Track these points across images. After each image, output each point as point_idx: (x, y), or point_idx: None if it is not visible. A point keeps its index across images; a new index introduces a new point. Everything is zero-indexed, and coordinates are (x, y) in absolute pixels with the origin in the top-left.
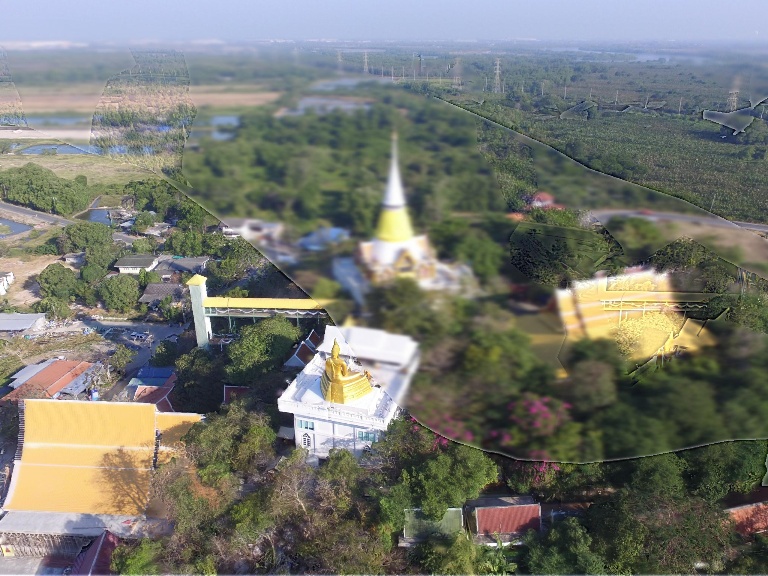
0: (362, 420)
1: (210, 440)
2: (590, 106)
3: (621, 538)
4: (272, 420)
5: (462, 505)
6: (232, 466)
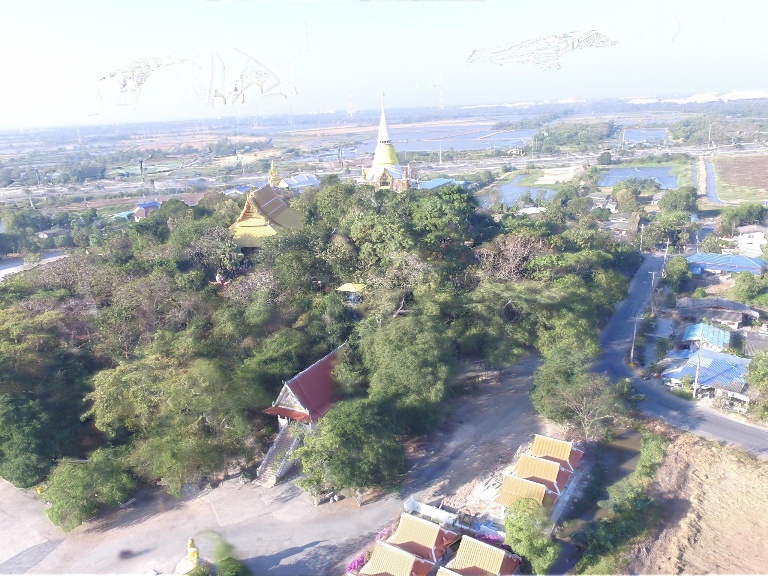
0: None
1: None
2: (435, 75)
3: None
4: None
5: None
6: None
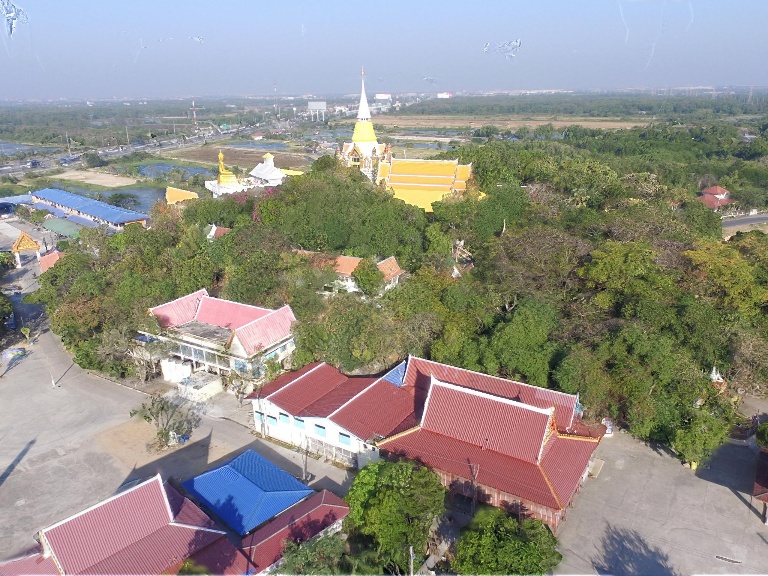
0: None
1: None
2: None
3: None
4: None
5: (216, 225)
6: None
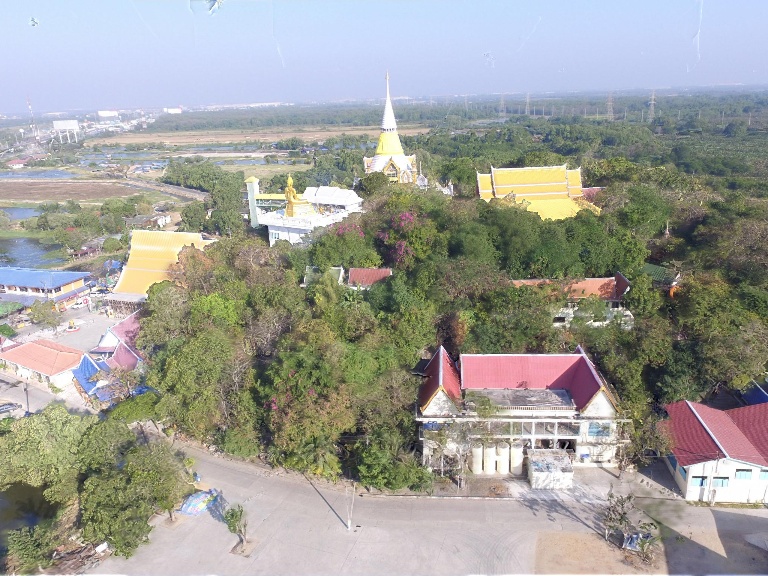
0: (300, 224)
1: (221, 244)
2: None
3: (420, 272)
4: (262, 240)
5: (343, 267)
6: (230, 259)
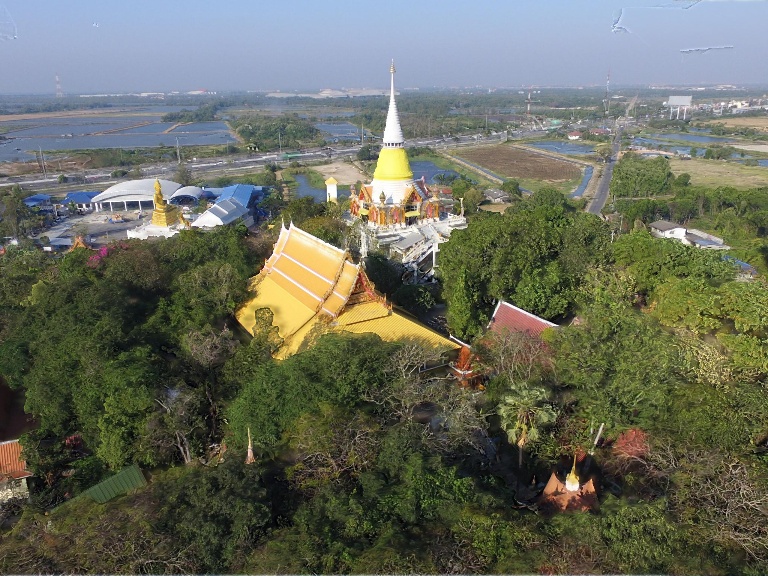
0: None
1: None
2: None
3: None
4: None
5: None
6: None
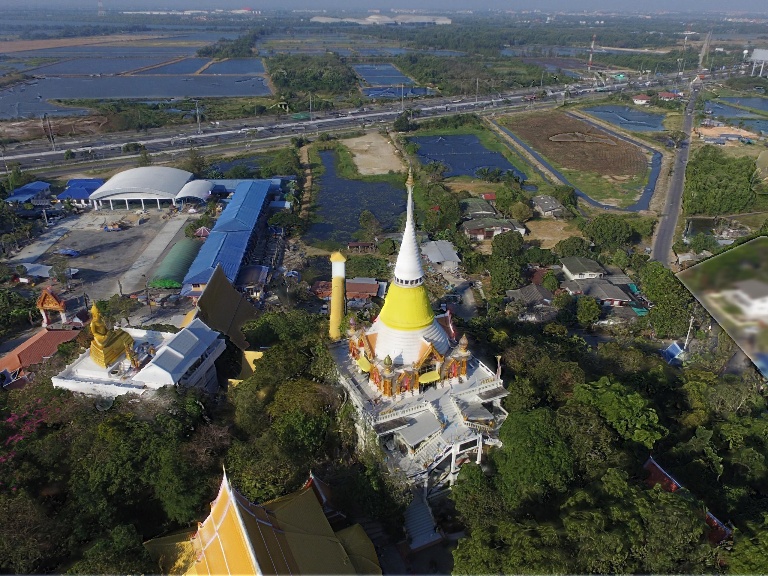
0: None
1: None
2: None
3: None
4: None
5: None
6: None
